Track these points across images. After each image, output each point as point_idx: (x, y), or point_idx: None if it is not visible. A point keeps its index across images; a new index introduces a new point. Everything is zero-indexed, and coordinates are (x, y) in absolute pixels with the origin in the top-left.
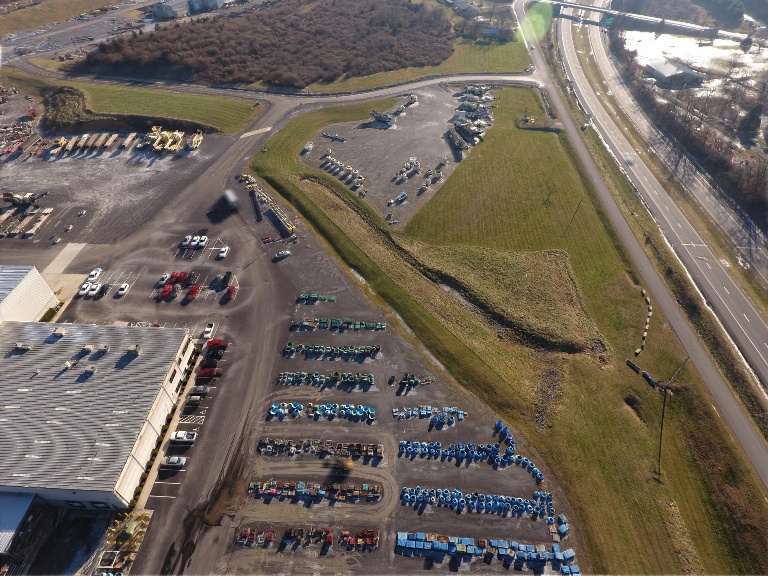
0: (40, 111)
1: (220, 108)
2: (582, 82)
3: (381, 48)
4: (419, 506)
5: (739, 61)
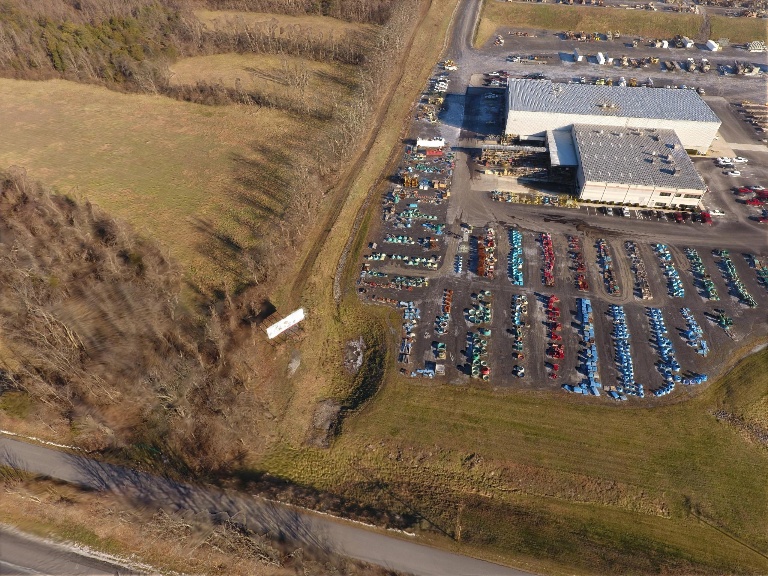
0: None
1: None
2: None
3: None
4: (611, 313)
5: None
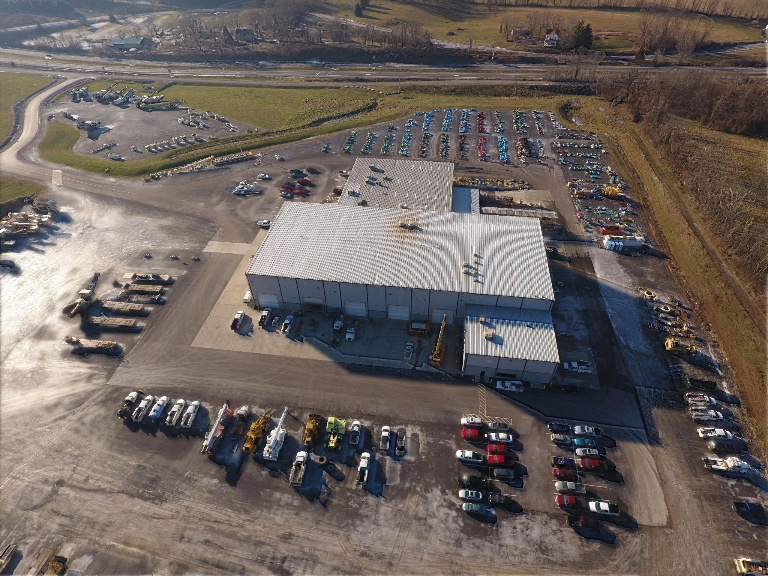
0: None
1: None
2: None
3: None
4: None
5: (154, 22)
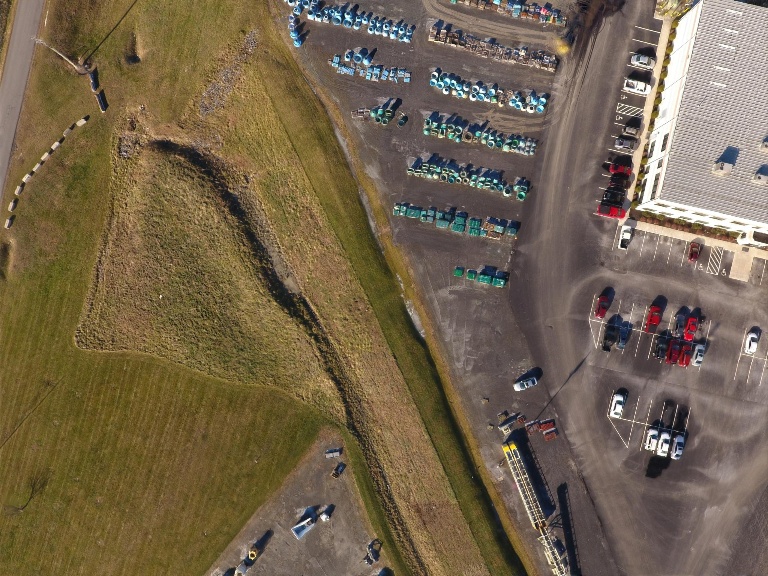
0: None
1: None
2: None
3: None
4: None
5: None
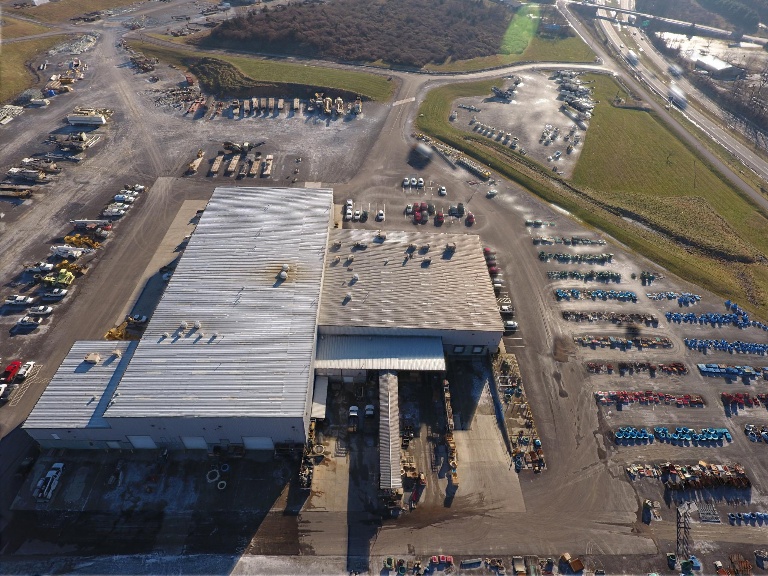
0: (193, 78)
1: (362, 80)
2: (646, 72)
3: (469, 36)
4: (702, 350)
5: None
